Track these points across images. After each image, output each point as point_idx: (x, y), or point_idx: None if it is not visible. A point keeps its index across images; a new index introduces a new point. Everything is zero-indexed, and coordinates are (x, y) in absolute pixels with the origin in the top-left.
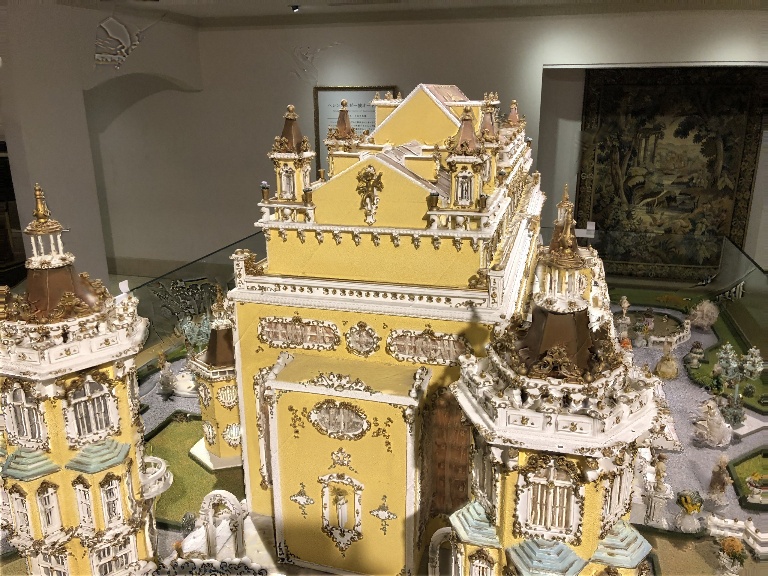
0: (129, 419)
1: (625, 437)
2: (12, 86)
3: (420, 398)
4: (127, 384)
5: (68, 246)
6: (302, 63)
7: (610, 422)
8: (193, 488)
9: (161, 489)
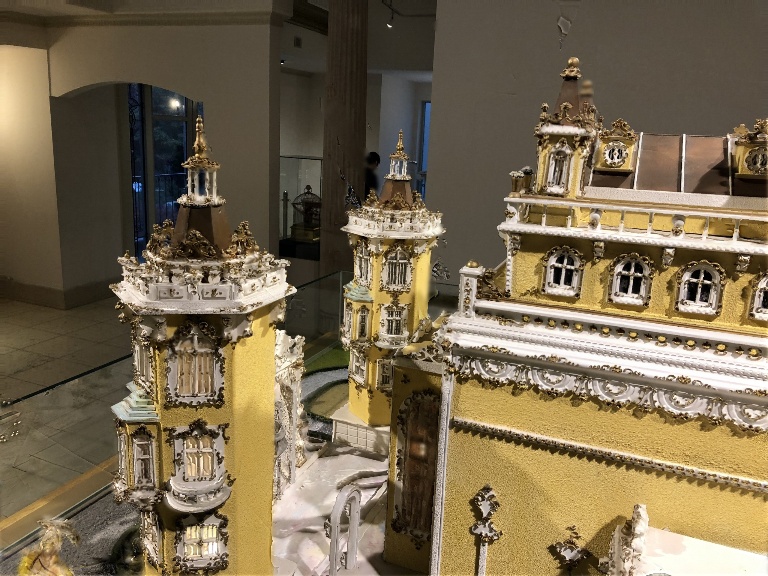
0: (377, 284)
1: (125, 294)
2: (453, 74)
3: (405, 365)
4: (382, 262)
5: (414, 173)
6: None
7: (126, 274)
8: None
9: (383, 345)
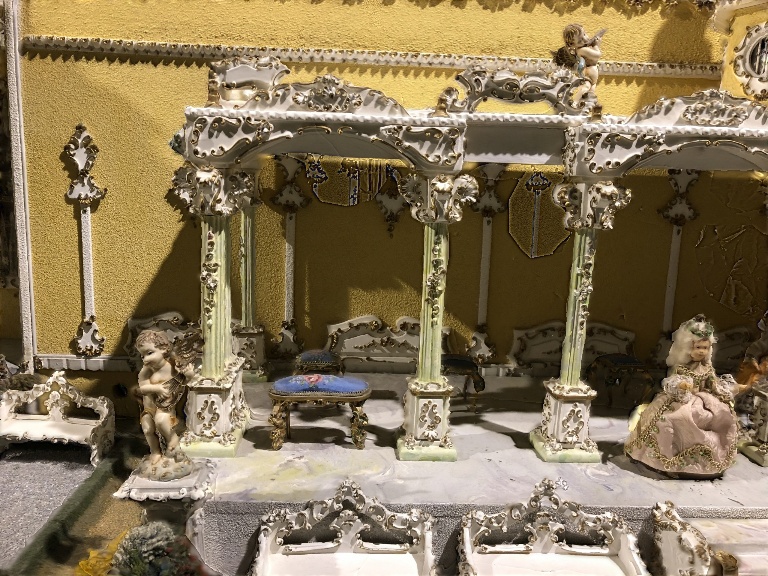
0: None
1: None
2: None
3: None
4: None
5: None
6: None
7: None
8: None
9: None
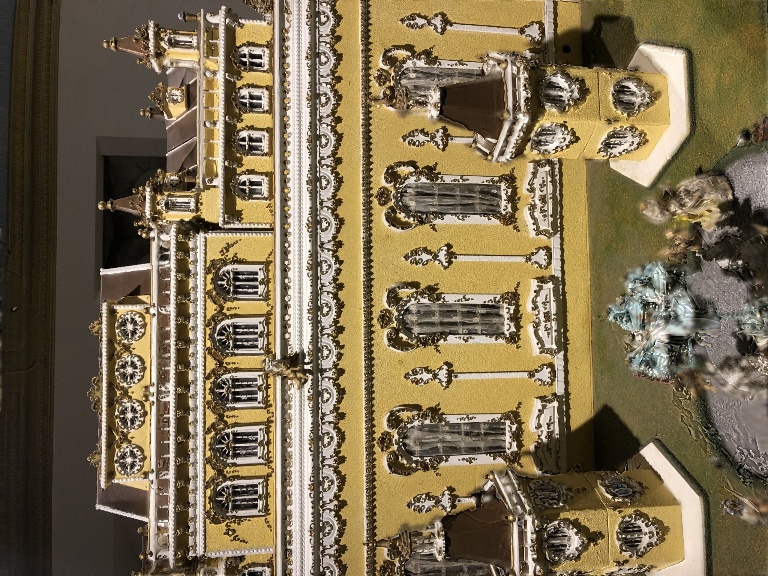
0: None
1: None
2: None
3: None
4: None
5: None
6: (3, 291)
7: None
8: (648, 0)
9: None
